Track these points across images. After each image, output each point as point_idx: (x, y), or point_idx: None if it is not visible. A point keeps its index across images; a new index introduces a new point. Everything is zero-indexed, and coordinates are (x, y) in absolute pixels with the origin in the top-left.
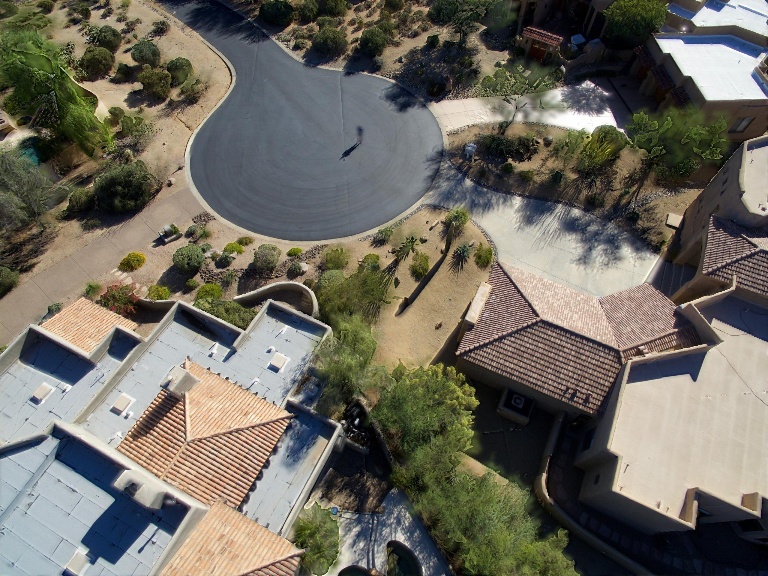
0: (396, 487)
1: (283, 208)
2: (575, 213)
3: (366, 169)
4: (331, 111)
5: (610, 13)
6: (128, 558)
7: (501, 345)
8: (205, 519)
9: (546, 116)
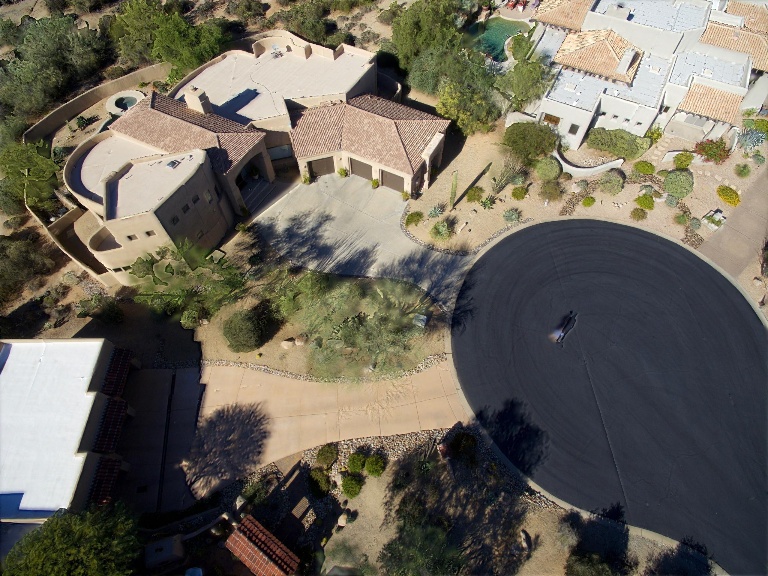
0: None
1: (619, 251)
2: (314, 264)
3: (543, 299)
4: (615, 406)
5: (118, 572)
6: None
7: (422, 118)
8: (582, 23)
9: (303, 396)
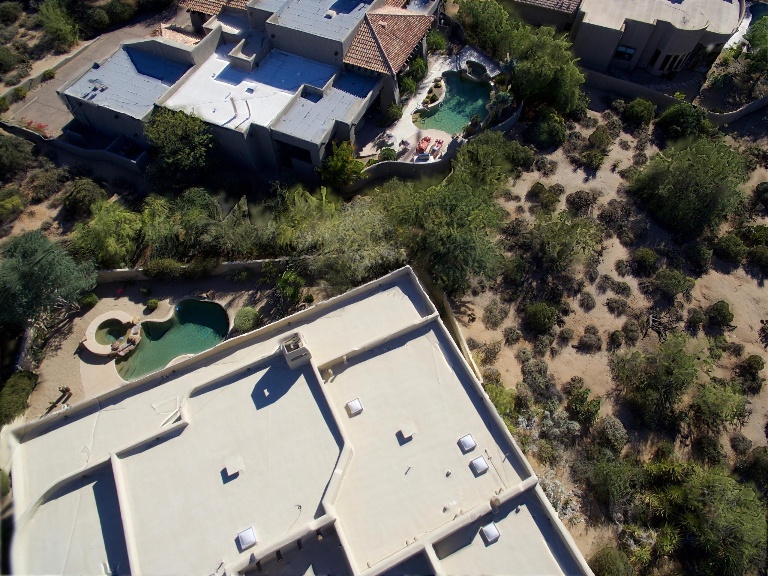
0: (468, 44)
1: None
2: None
3: None
4: None
5: None
6: (354, 12)
7: None
8: None
9: None
